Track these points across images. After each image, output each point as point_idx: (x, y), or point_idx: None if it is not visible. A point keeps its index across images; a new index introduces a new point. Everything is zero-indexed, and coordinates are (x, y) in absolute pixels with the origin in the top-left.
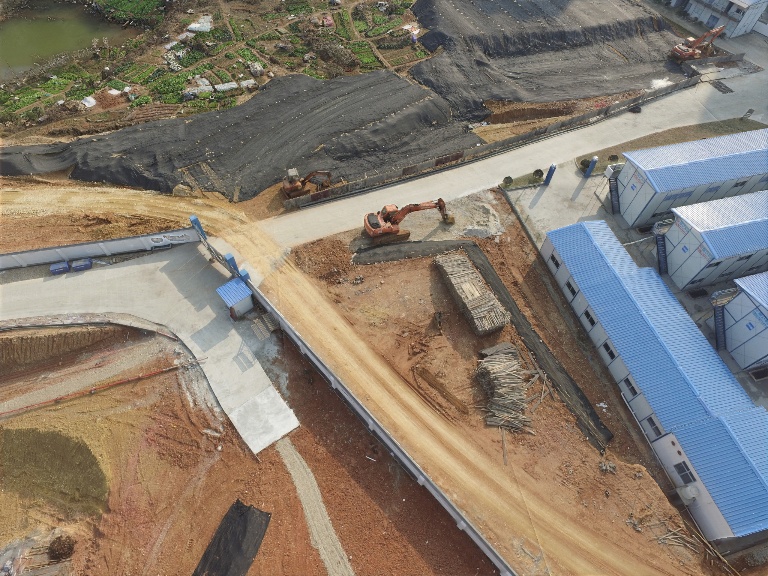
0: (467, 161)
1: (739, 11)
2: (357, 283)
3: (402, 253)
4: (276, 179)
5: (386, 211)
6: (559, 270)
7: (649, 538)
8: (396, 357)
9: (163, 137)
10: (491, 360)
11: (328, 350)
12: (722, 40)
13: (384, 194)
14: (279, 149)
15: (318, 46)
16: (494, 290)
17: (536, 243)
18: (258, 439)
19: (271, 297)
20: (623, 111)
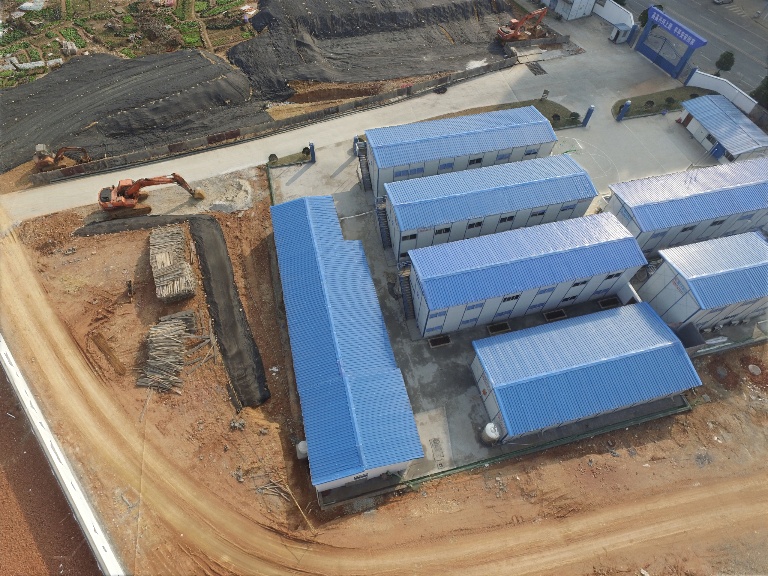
0: (246, 139)
1: None
2: (68, 254)
3: (125, 226)
4: None
5: (119, 185)
6: None
7: (248, 488)
8: (78, 323)
9: None
10: (159, 325)
11: (13, 316)
12: (559, 22)
13: (144, 170)
14: (51, 126)
15: (143, 26)
16: (201, 261)
17: None
18: None
19: None
20: (427, 92)
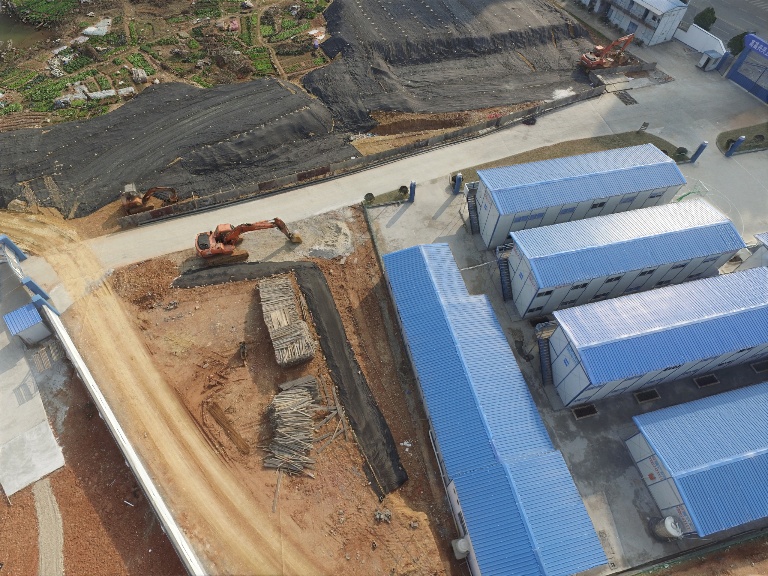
0: (335, 175)
1: (655, 18)
2: (170, 308)
3: (227, 276)
4: (120, 194)
5: (218, 231)
6: None
7: None
8: (189, 390)
9: (13, 148)
10: (283, 396)
11: (118, 382)
12: (640, 48)
13: (235, 211)
14: (133, 162)
15: (212, 52)
16: (314, 317)
17: (382, 265)
18: (15, 480)
19: (75, 323)
20: (516, 123)
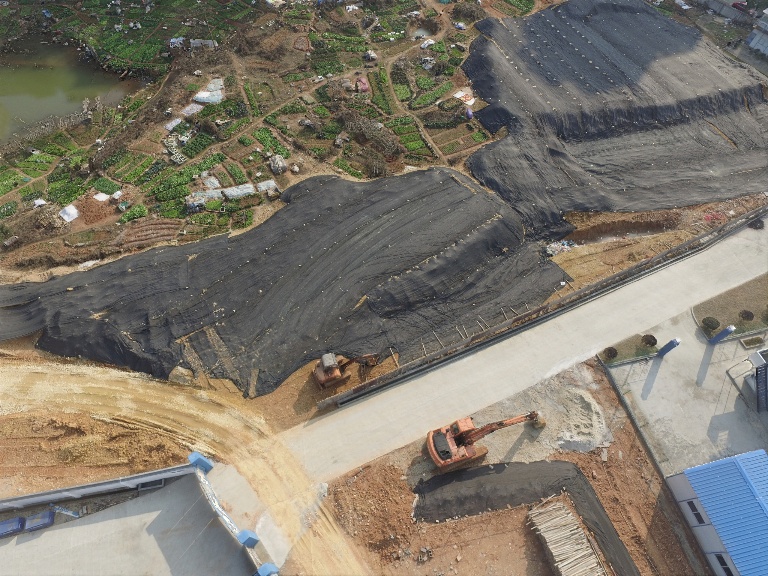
0: (551, 313)
1: None
2: (423, 561)
3: (483, 500)
4: (305, 357)
5: (459, 430)
6: (703, 528)
7: None
8: None
9: (158, 284)
10: None
11: None
12: None
13: (448, 375)
14: (308, 303)
15: (353, 126)
16: (618, 575)
17: (659, 464)
18: None
19: None
20: (741, 227)
